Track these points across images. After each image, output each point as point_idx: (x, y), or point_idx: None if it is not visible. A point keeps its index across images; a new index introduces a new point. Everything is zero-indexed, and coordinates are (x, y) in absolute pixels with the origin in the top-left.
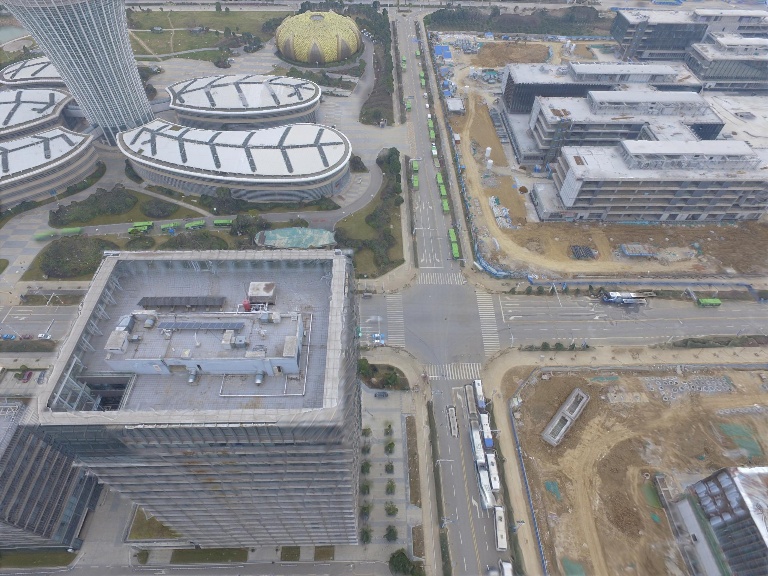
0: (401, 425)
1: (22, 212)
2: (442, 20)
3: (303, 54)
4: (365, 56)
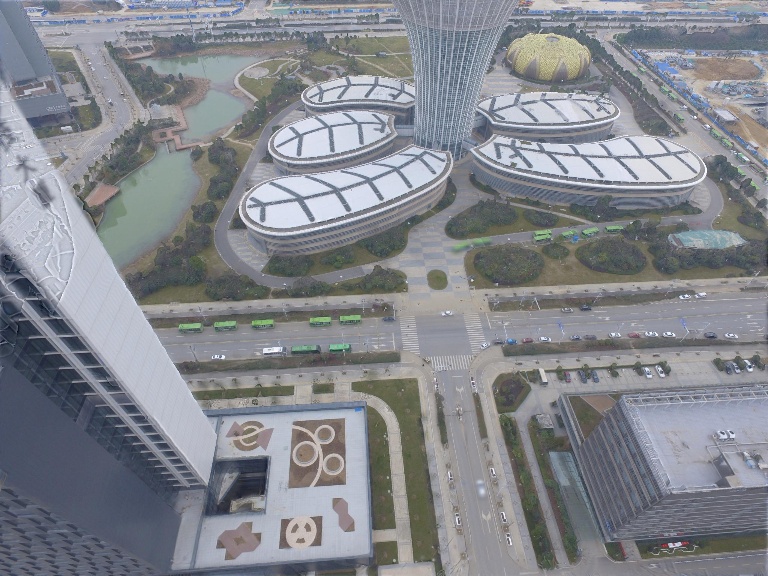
0: None
1: (413, 226)
2: (639, 39)
3: (549, 73)
4: (594, 74)
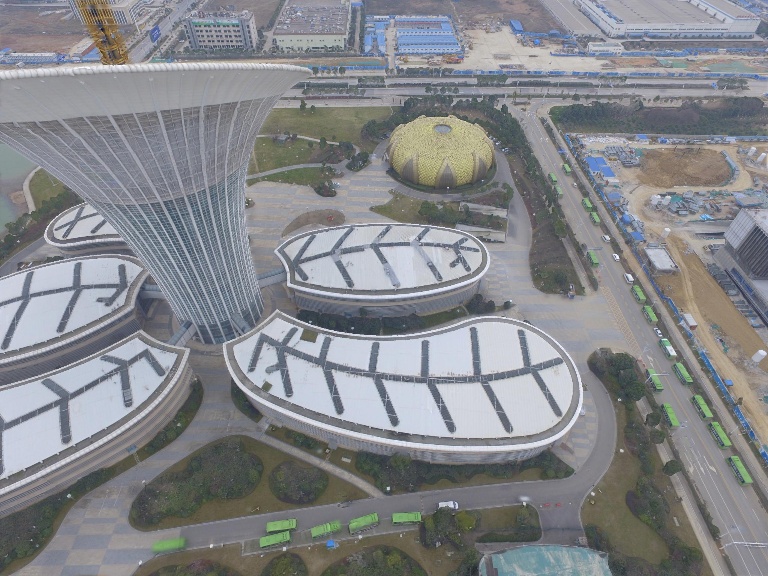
0: None
1: (87, 492)
2: (578, 118)
3: (430, 177)
4: (501, 173)
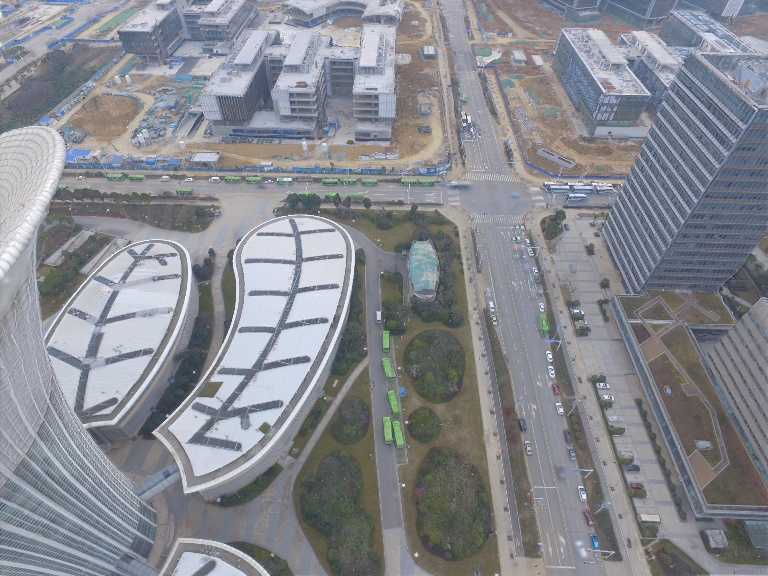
0: (585, 220)
1: None
2: None
3: None
4: None
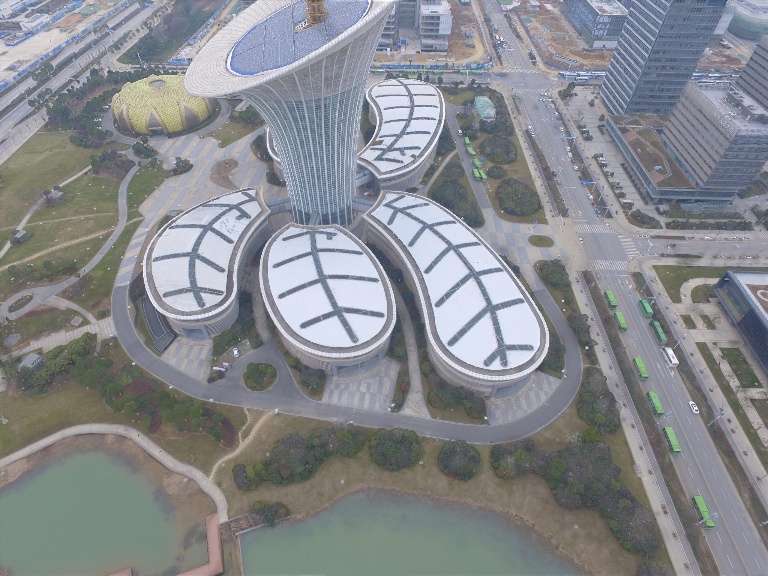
0: (588, 91)
1: None
2: (152, 52)
3: (204, 111)
4: None
